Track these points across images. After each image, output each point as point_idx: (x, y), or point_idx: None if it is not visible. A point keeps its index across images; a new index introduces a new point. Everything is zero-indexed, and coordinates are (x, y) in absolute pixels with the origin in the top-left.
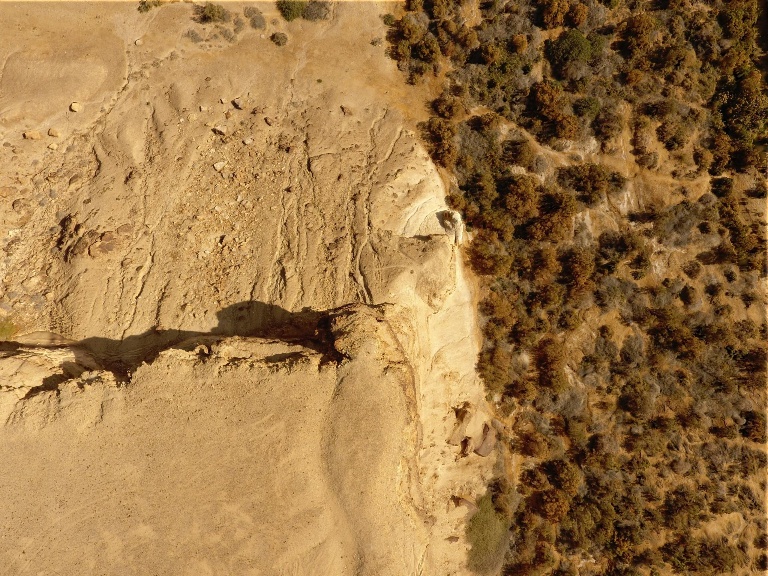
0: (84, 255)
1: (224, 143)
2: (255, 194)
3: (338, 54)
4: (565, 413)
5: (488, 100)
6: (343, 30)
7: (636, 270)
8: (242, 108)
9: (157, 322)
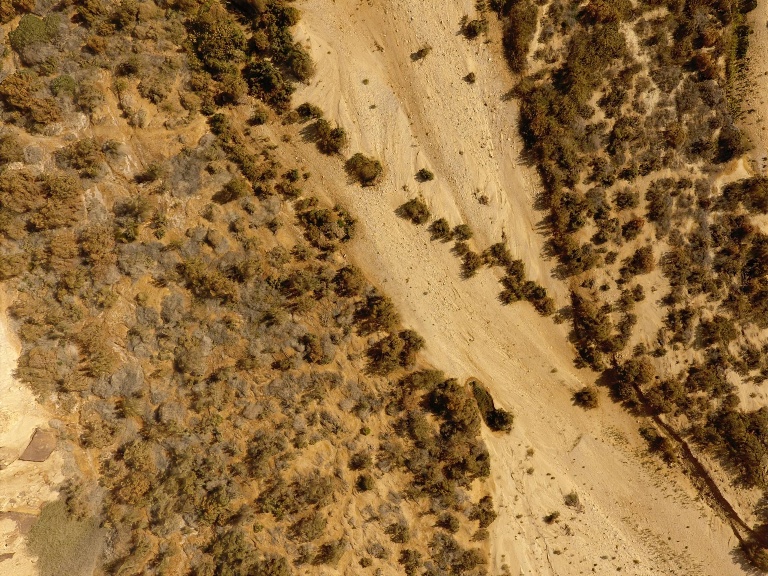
0: None
1: None
2: None
3: None
4: (124, 392)
5: None
6: None
7: (157, 230)
8: None
9: None
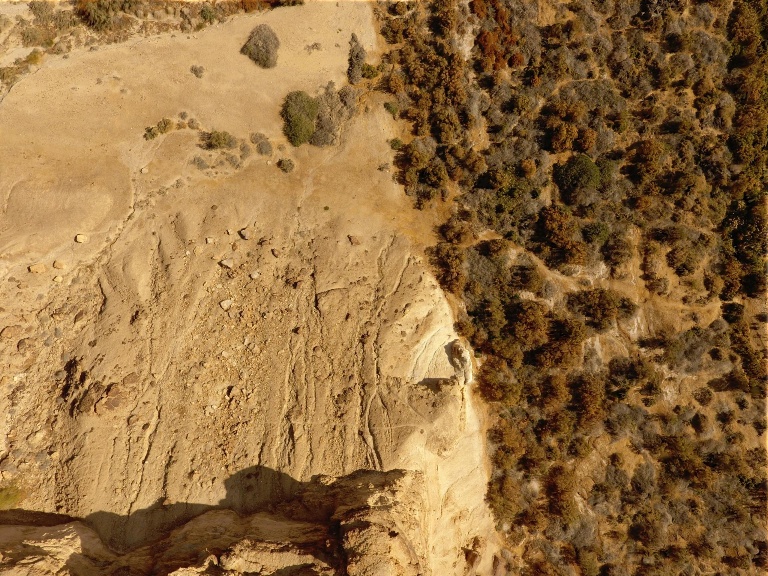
0: (90, 413)
1: (231, 278)
2: (262, 336)
3: (345, 180)
4: (575, 542)
5: (496, 225)
6: (350, 156)
7: (647, 397)
8: (249, 239)
9: (164, 493)
